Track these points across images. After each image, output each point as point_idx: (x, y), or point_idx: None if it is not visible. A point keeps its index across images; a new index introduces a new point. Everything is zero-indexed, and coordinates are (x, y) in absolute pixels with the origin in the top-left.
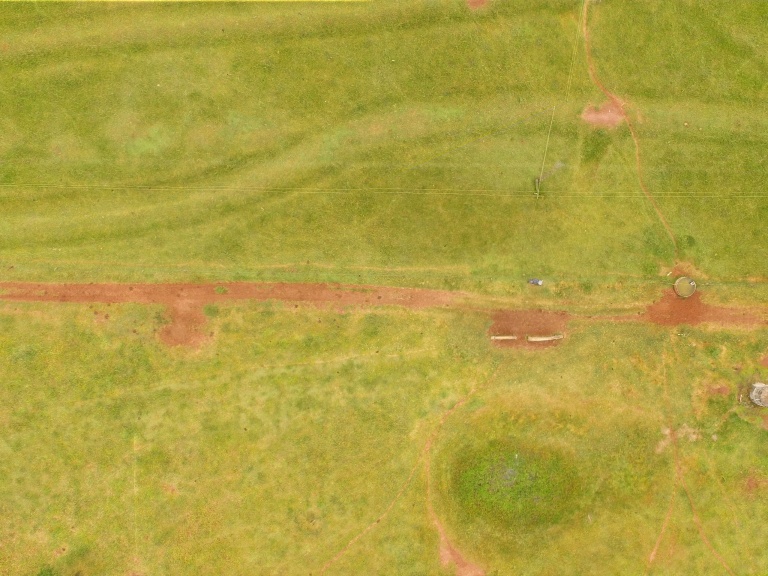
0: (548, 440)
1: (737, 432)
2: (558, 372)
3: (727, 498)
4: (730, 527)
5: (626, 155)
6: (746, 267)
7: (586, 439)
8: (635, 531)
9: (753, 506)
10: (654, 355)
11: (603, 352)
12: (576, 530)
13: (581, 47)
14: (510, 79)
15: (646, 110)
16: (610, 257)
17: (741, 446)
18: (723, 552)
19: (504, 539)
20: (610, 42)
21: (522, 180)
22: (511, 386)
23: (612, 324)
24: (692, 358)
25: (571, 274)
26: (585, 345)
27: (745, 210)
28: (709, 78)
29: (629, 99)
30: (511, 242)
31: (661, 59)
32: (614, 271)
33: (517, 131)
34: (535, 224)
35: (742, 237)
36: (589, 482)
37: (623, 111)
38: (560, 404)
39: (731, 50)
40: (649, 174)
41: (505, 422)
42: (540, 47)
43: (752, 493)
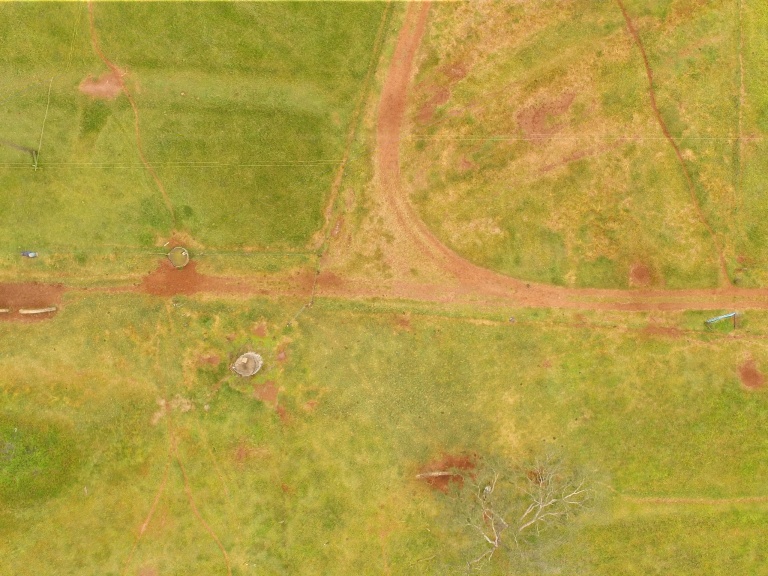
0: (46, 413)
1: (228, 402)
2: (51, 344)
3: (218, 468)
4: (219, 497)
5: (124, 126)
6: (242, 236)
7: (83, 411)
8: (129, 503)
9: (243, 475)
10: (148, 326)
11: (97, 324)
12: (72, 503)
13: (83, 18)
14: (11, 51)
15: (145, 80)
16: (107, 228)
17: (233, 416)
18: (212, 522)
19: (2, 514)
20: (113, 13)
21: (20, 152)
22: (3, 359)
23: (108, 295)
24: (185, 328)
25: (66, 246)
26: (80, 317)
27: (243, 179)
28: (211, 48)
29: (130, 70)
30: (8, 215)
31: (163, 29)
32: (110, 242)
33: (15, 103)
34: (33, 196)
35: (239, 206)
36: (86, 455)
37: (122, 82)
38: (56, 377)
39: (234, 19)
40: (148, 144)
41: (0, 396)
42: (42, 18)
43: (242, 462)
